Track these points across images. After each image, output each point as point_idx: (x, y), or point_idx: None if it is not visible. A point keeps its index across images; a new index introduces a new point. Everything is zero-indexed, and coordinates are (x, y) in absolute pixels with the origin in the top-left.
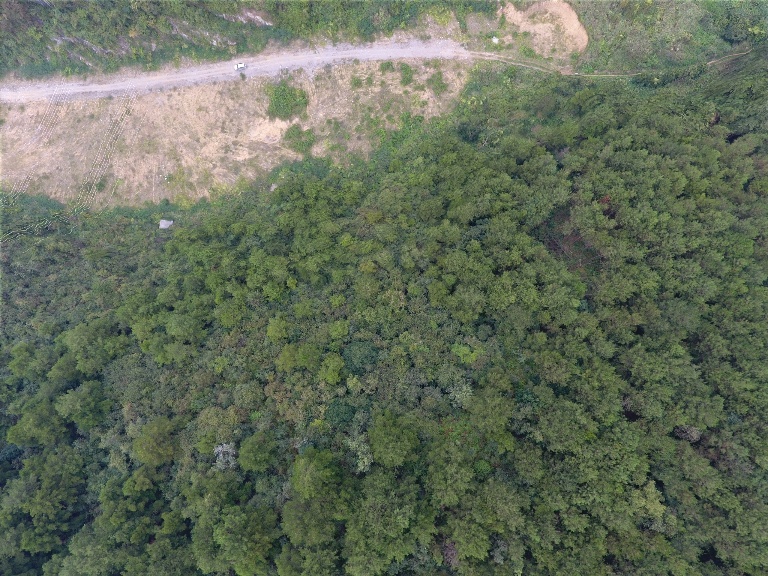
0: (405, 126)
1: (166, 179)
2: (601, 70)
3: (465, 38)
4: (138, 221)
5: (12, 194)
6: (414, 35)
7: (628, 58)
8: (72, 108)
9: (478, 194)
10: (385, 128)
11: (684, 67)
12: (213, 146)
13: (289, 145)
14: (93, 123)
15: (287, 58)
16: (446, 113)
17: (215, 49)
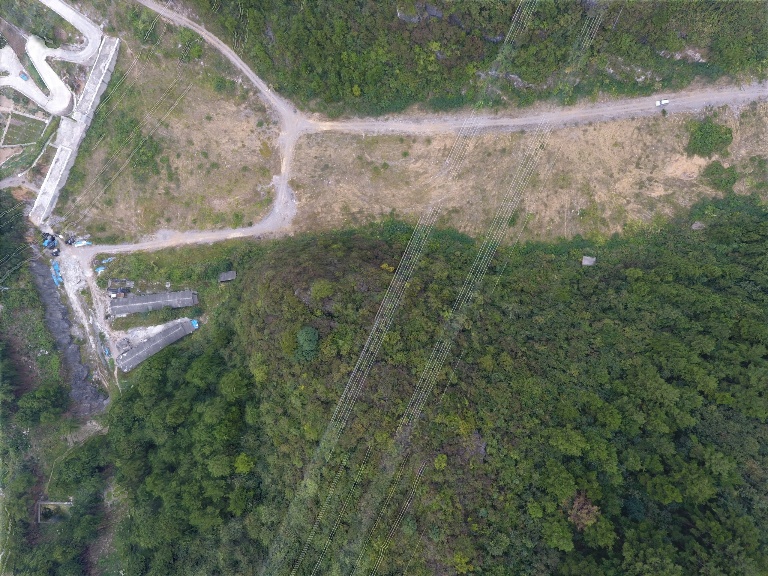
0: None
1: (578, 214)
2: None
3: None
4: (560, 257)
5: (422, 228)
6: None
7: None
8: (481, 142)
9: None
10: None
11: None
12: (627, 182)
13: (709, 182)
14: (505, 157)
15: (711, 95)
16: None
17: (641, 85)
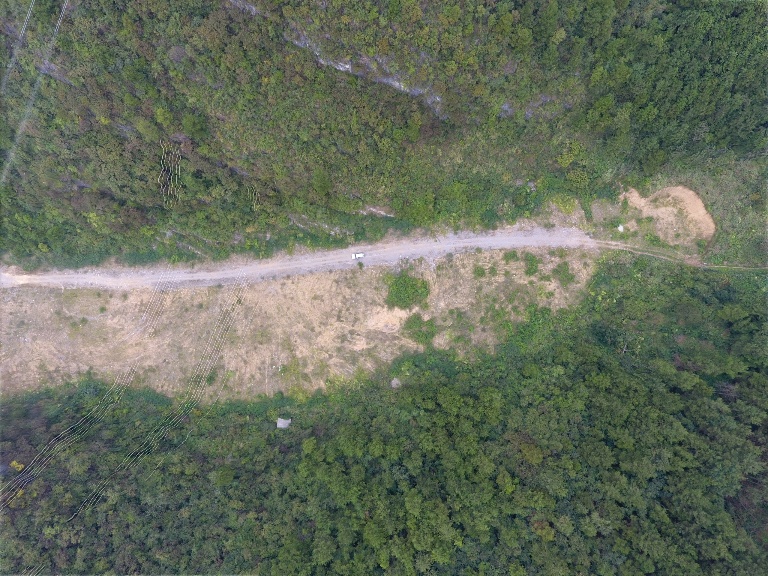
0: (533, 320)
1: (280, 370)
2: (731, 262)
3: (590, 227)
4: (254, 420)
5: (116, 389)
6: (537, 223)
7: (759, 250)
8: (179, 296)
9: (652, 446)
10: (511, 320)
11: None
12: (329, 335)
13: (409, 335)
14: (202, 313)
15: (407, 247)
16: (574, 305)
17: (333, 239)
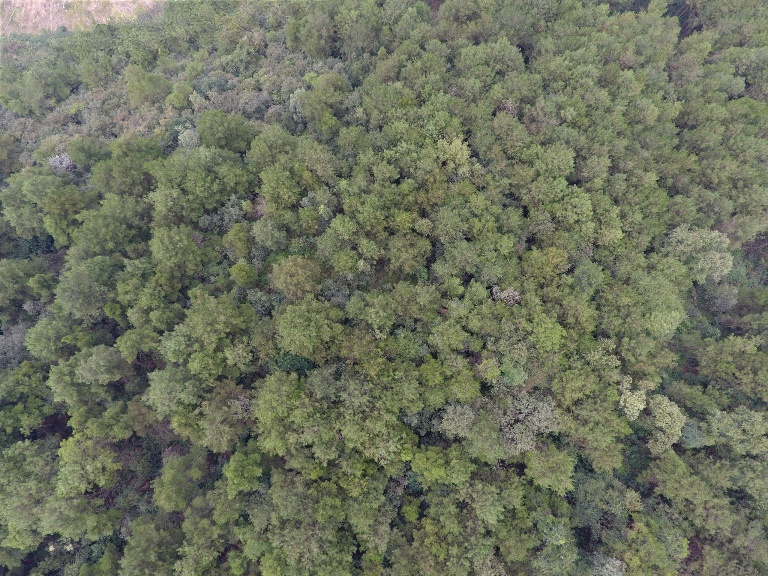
0: None
1: (64, 8)
2: None
3: None
4: (33, 43)
5: None
6: None
7: None
8: None
9: None
10: None
11: None
12: None
13: None
14: None
15: None
16: None
17: None
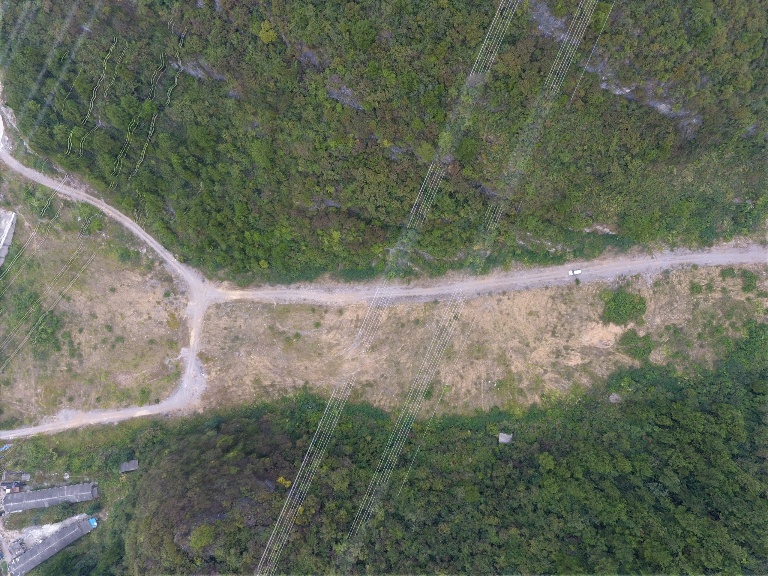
0: (754, 336)
1: (495, 385)
2: None
3: None
4: (476, 435)
5: (335, 403)
6: (753, 240)
7: None
8: (394, 312)
9: None
10: (729, 336)
11: None
12: (543, 351)
13: (625, 351)
14: (418, 328)
15: (624, 263)
16: None
17: (552, 256)
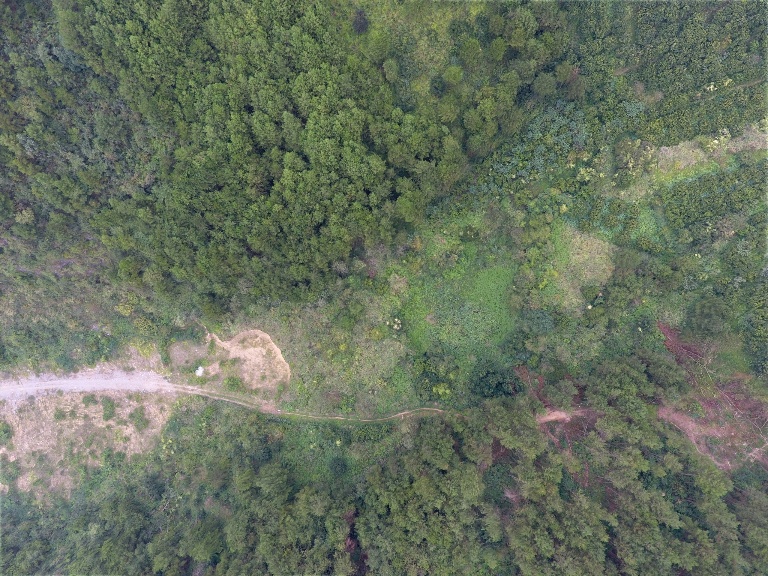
0: (104, 467)
1: None
2: (301, 410)
3: (167, 371)
4: None
5: None
6: (117, 366)
7: (327, 399)
8: None
9: None
10: (88, 464)
11: (379, 415)
12: None
13: None
14: None
15: None
16: (147, 451)
17: None
